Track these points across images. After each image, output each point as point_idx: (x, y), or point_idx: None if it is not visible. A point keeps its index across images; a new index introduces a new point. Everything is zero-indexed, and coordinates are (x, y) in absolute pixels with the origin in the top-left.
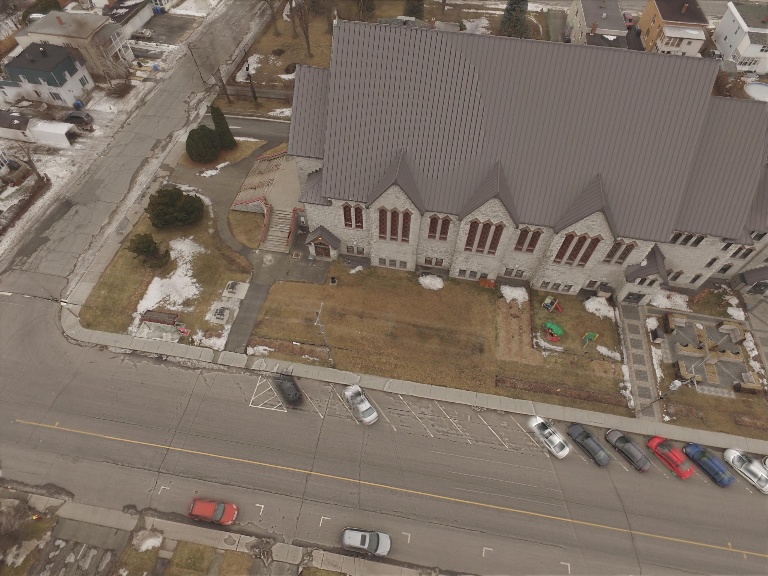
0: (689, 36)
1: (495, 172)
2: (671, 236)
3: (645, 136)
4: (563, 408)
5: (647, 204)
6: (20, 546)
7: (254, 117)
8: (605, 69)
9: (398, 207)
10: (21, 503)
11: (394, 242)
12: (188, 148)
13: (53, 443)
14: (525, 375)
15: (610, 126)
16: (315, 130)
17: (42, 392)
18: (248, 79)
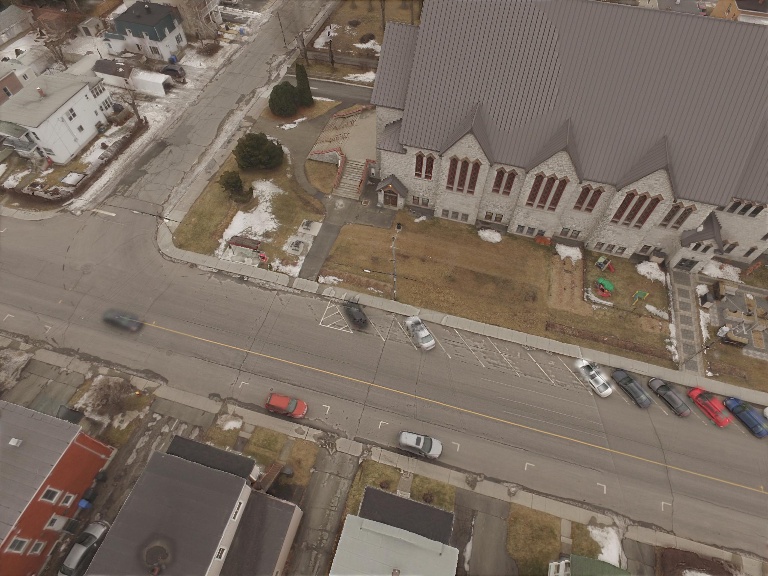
0: None
1: (565, 128)
2: (730, 204)
3: (715, 101)
4: (609, 355)
5: (710, 168)
6: (125, 414)
7: (330, 80)
8: (682, 34)
9: (469, 157)
10: (125, 381)
11: (460, 193)
12: (271, 102)
13: (151, 338)
14: (574, 323)
15: (681, 90)
16: (398, 82)
17: (142, 296)
18: (325, 46)
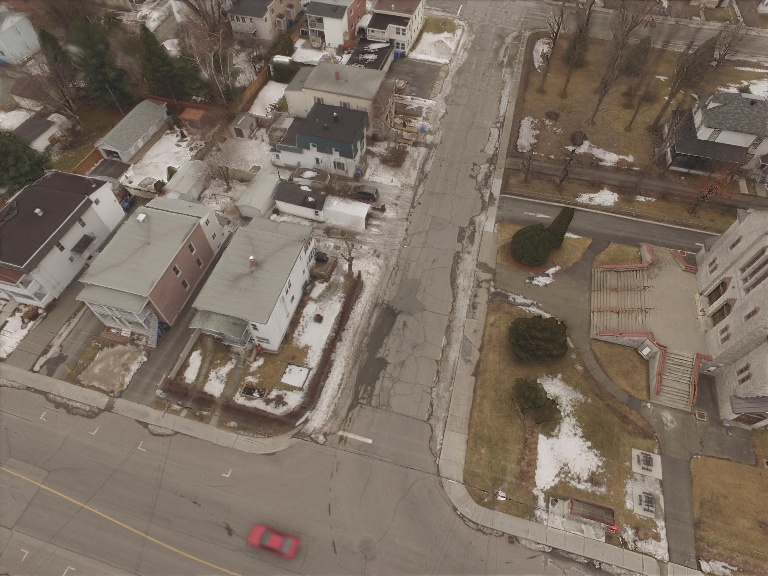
0: None
1: None
2: None
3: None
4: None
5: None
6: None
7: (562, 204)
8: None
9: None
10: None
11: None
12: (521, 250)
13: None
14: None
15: None
16: None
17: None
18: None
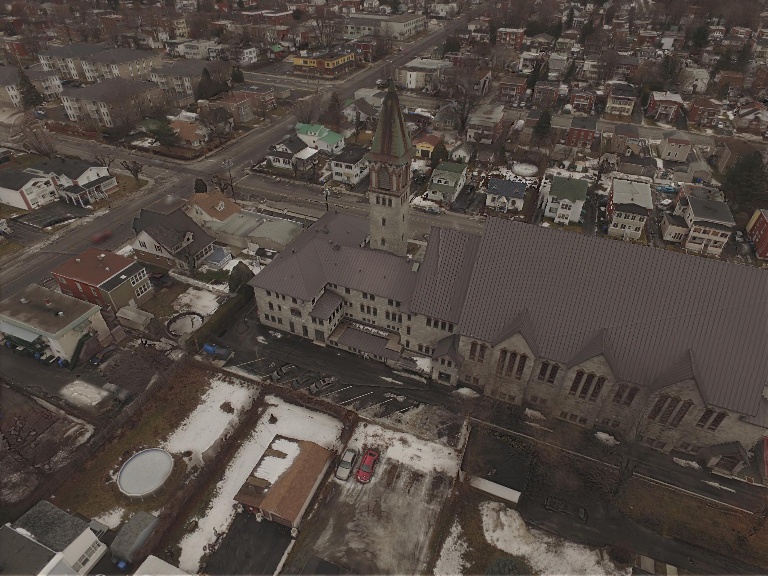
0: (170, 571)
1: None
2: None
3: None
4: None
5: None
6: None
7: None
8: None
9: None
10: None
11: None
12: None
13: None
14: None
15: None
16: None
17: None
18: None
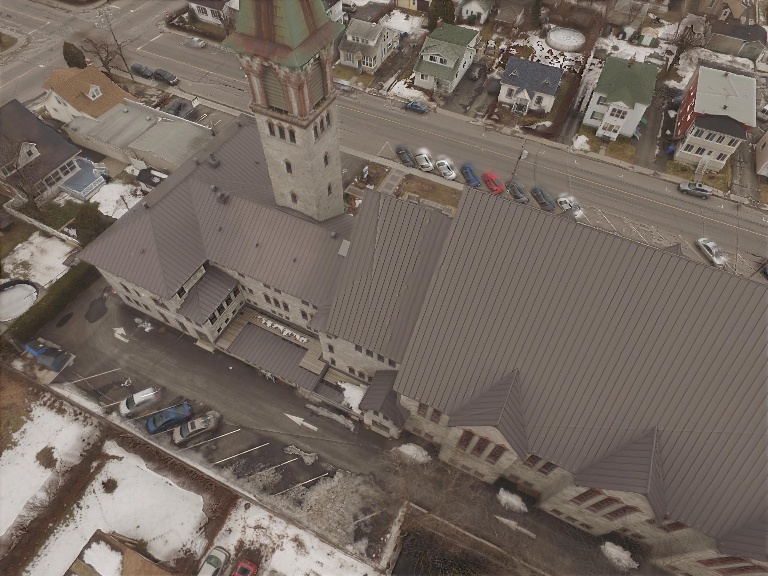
0: None
1: None
2: None
3: None
4: None
5: None
6: None
7: None
8: None
9: None
10: None
11: None
12: None
13: None
14: None
15: None
16: None
17: None
18: None
